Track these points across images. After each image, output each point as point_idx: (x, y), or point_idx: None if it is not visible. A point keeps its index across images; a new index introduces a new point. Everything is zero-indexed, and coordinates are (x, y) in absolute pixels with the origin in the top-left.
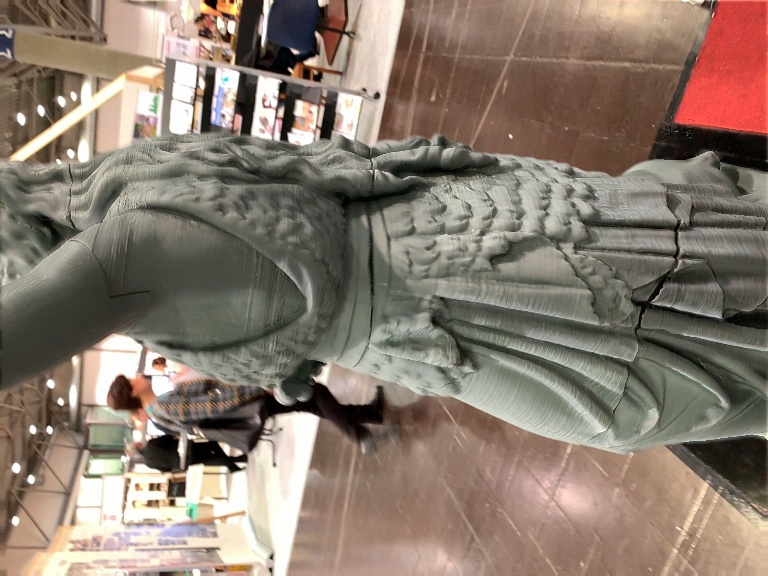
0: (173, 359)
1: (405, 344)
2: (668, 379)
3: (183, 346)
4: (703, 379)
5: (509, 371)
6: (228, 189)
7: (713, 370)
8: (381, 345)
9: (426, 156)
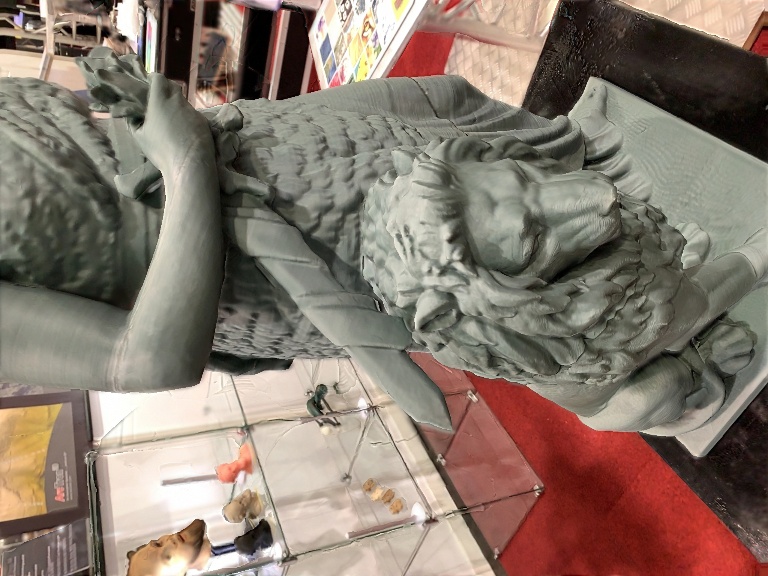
0: None
1: None
2: None
3: None
4: None
5: None
6: None
7: None
8: None
9: None
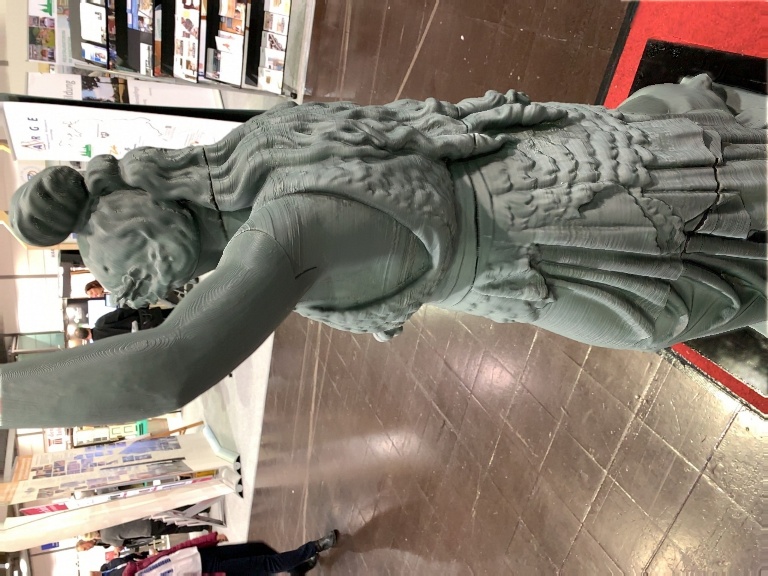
0: (320, 319)
1: (504, 285)
2: (696, 290)
3: (332, 308)
4: (724, 288)
5: (580, 298)
6: (371, 168)
7: (729, 279)
8: (484, 288)
9: (511, 115)
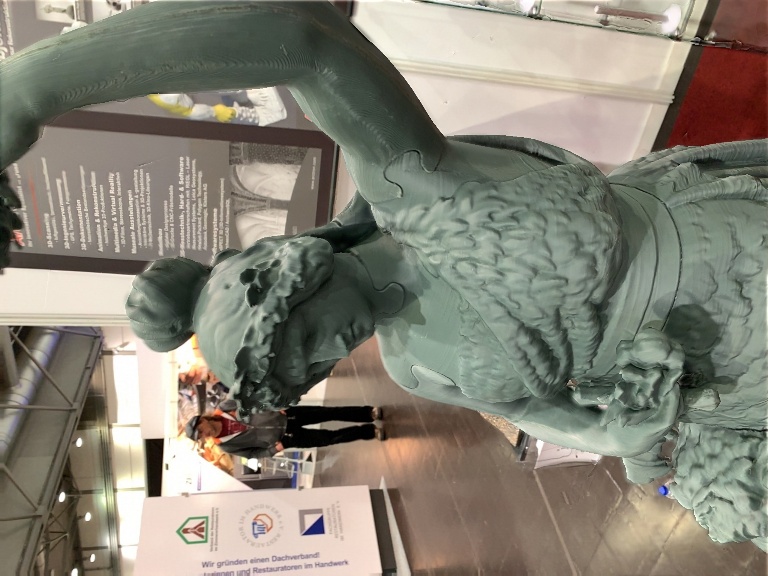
0: (491, 200)
1: None
2: None
3: None
4: None
5: None
6: None
7: None
8: (675, 193)
9: None
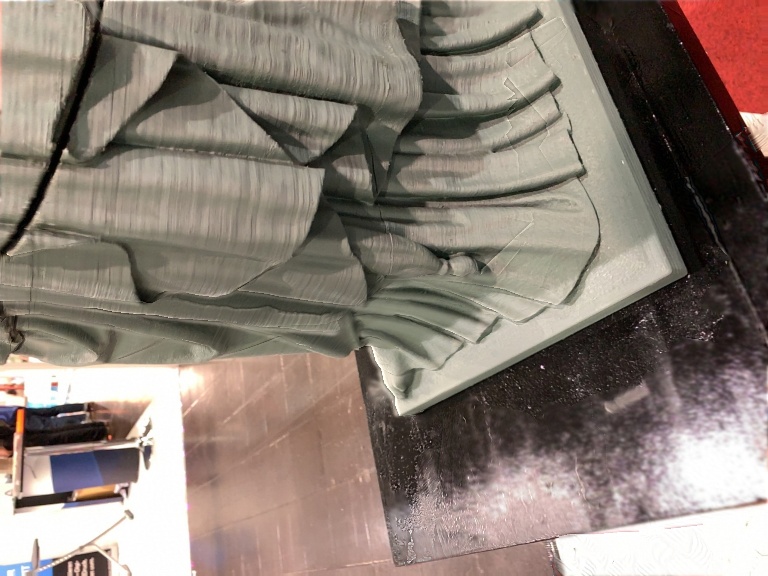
0: None
1: None
2: None
3: None
4: (160, 335)
5: None
6: None
7: None
8: None
9: None
